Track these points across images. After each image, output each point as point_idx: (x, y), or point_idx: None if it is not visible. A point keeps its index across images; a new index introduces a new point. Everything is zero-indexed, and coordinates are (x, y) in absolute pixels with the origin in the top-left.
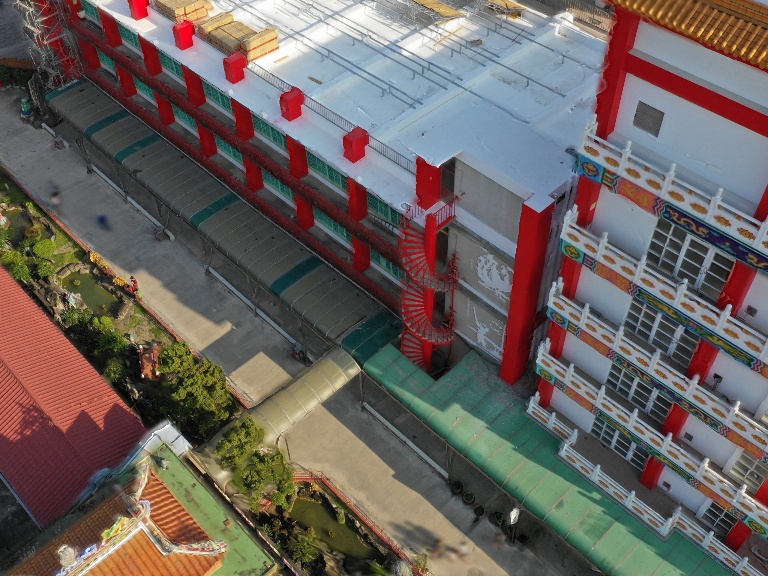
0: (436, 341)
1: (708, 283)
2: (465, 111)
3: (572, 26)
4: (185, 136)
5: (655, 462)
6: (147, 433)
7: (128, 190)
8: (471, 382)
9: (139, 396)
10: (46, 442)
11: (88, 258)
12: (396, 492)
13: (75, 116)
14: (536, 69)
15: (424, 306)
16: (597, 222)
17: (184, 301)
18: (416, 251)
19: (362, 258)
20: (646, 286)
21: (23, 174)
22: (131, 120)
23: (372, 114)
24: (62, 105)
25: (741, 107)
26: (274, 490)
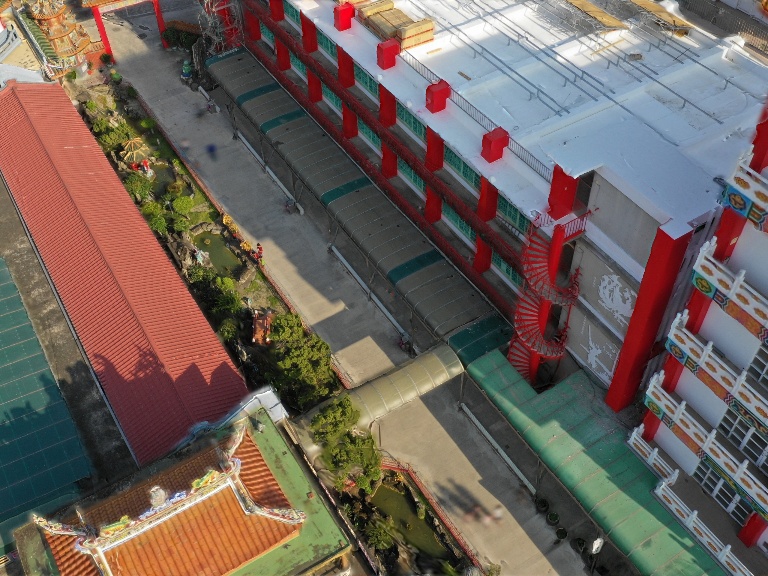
0: (545, 354)
1: None
2: (613, 125)
3: (742, 51)
4: (329, 115)
5: (758, 519)
6: (249, 395)
7: (268, 160)
8: (574, 402)
9: (247, 358)
10: (156, 387)
11: (221, 220)
12: (480, 498)
13: (230, 83)
14: (695, 91)
15: (538, 317)
16: (736, 258)
17: (303, 275)
18: (539, 260)
19: (483, 259)
20: None
21: (175, 132)
22: (281, 93)
23: (516, 116)
24: (220, 71)
25: None
26: (360, 473)
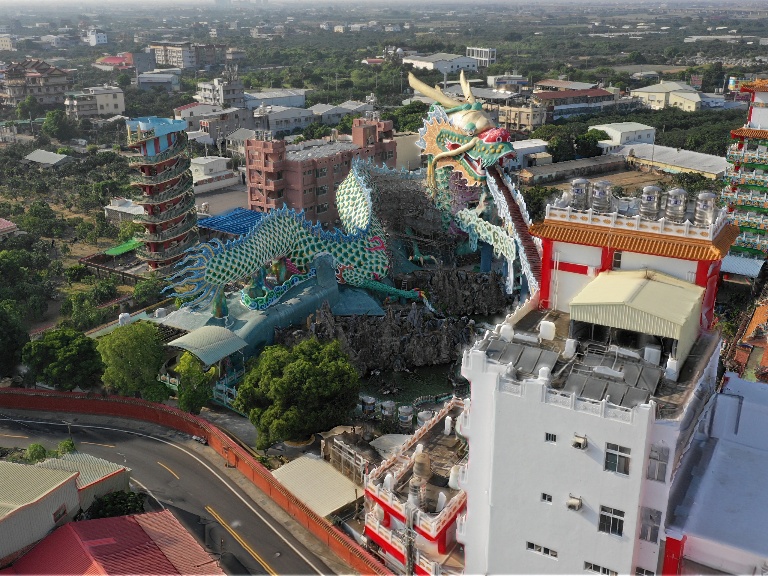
0: None
1: None
2: None
3: None
4: None
5: None
6: None
7: None
8: None
9: None
10: None
11: None
12: None
13: None
14: None
15: None
16: None
17: None
18: None
19: None
20: None
21: None
22: None
23: None
24: None
25: None
26: None
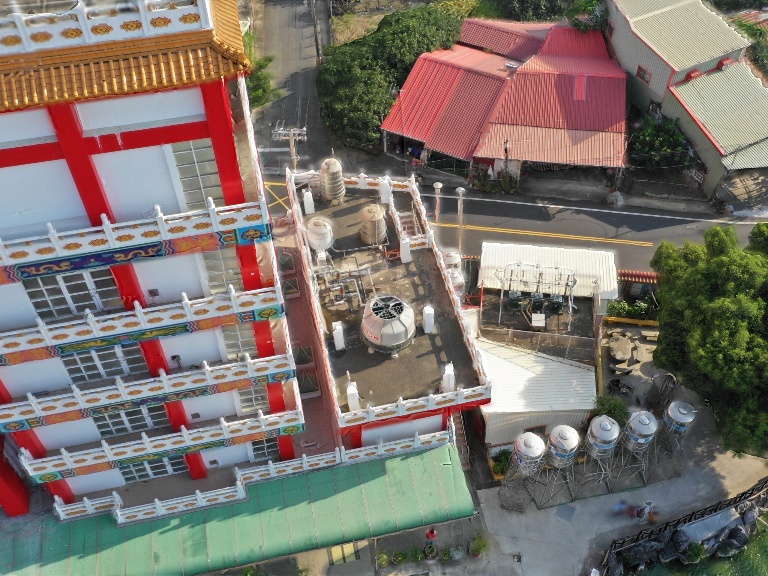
0: None
1: (105, 299)
2: None
3: None
4: None
5: (191, 456)
6: None
7: None
8: None
9: None
10: None
11: None
12: None
13: None
14: None
15: None
16: None
17: None
18: None
19: None
20: (62, 340)
21: None
22: None
23: None
24: None
25: (5, 152)
26: None
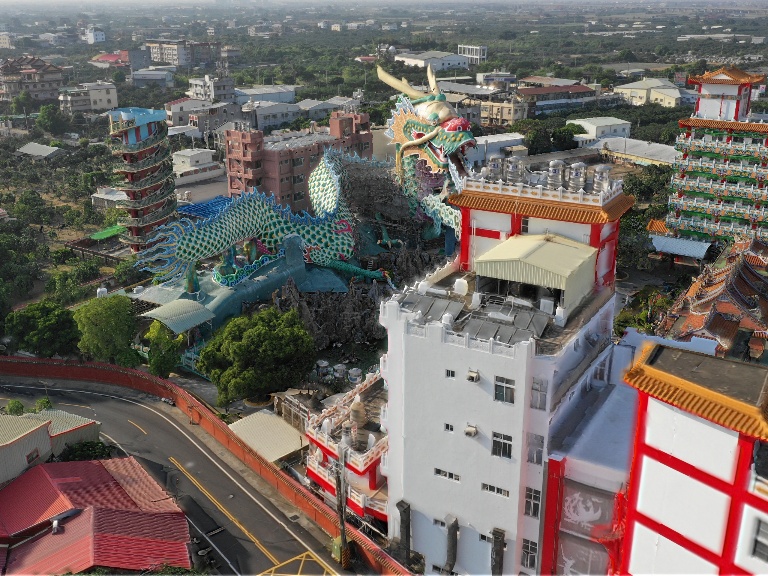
0: None
1: None
2: None
3: None
4: None
5: None
6: None
7: None
8: None
9: None
10: None
11: None
12: None
13: None
14: None
15: None
16: None
17: None
18: None
19: None
20: None
21: None
22: None
23: None
24: None
25: None
26: None
